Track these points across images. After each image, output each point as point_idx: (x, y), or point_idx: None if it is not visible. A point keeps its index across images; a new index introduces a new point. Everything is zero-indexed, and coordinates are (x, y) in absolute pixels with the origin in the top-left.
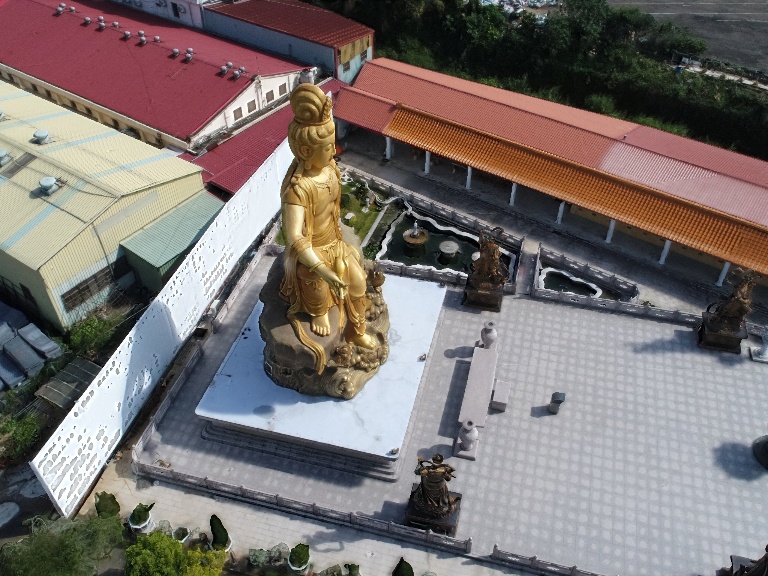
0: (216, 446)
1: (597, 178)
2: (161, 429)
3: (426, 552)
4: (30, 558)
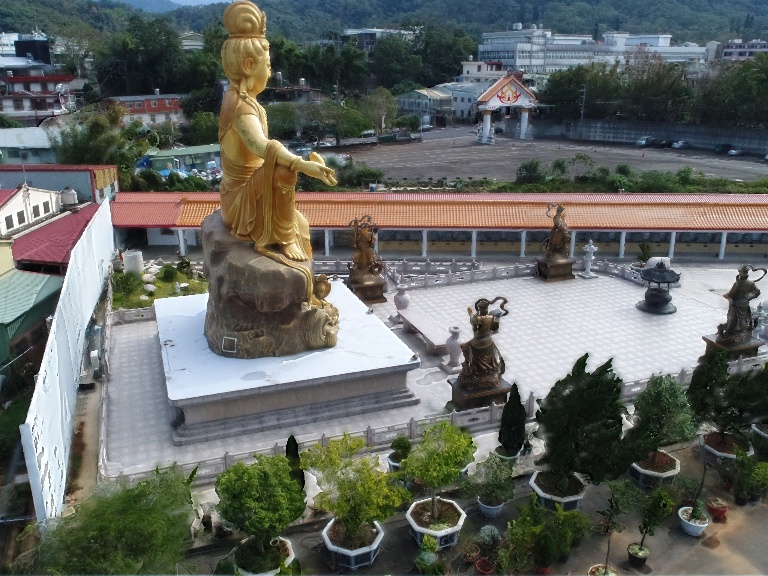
0: (201, 446)
1: (397, 205)
2: (113, 459)
3: (497, 432)
4: (93, 521)
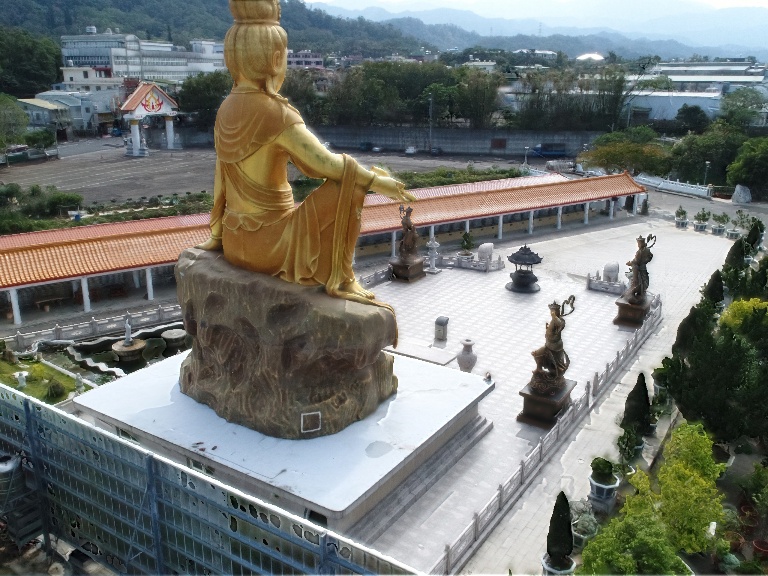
0: None
1: None
2: None
3: (583, 429)
4: None
